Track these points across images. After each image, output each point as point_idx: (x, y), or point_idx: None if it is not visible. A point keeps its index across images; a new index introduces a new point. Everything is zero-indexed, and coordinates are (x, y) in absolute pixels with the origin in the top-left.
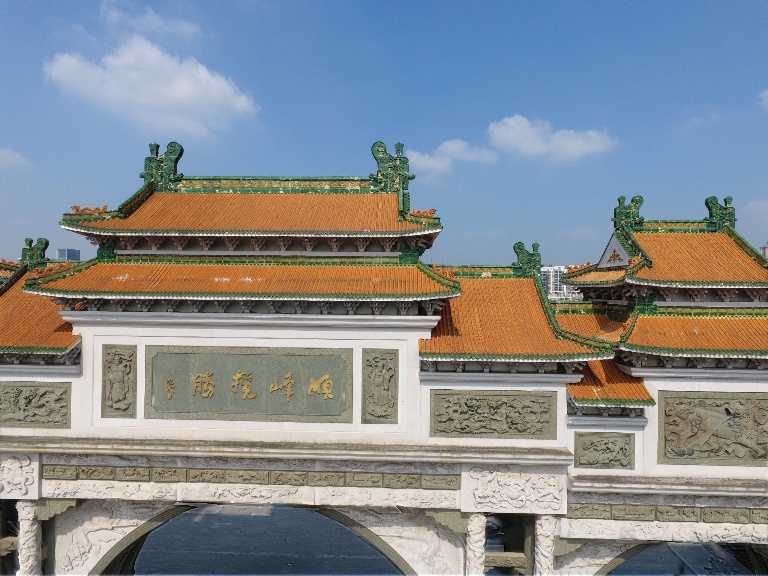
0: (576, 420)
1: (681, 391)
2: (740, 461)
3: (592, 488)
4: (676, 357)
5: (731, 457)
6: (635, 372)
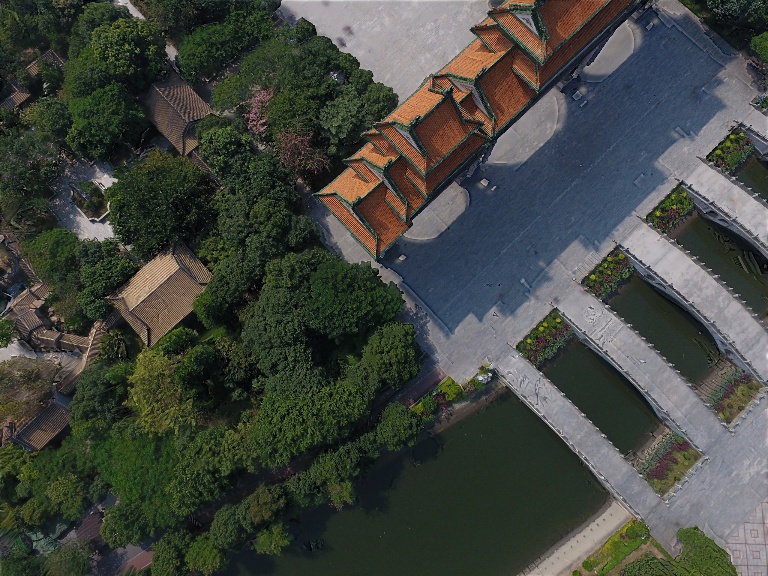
0: None
1: None
2: None
3: None
4: None
5: None
6: None
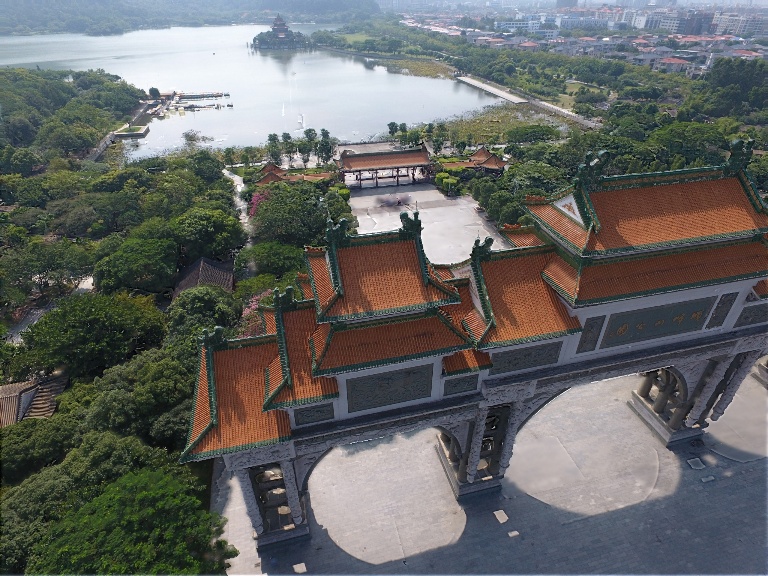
0: None
1: None
2: None
3: None
4: None
5: None
6: None
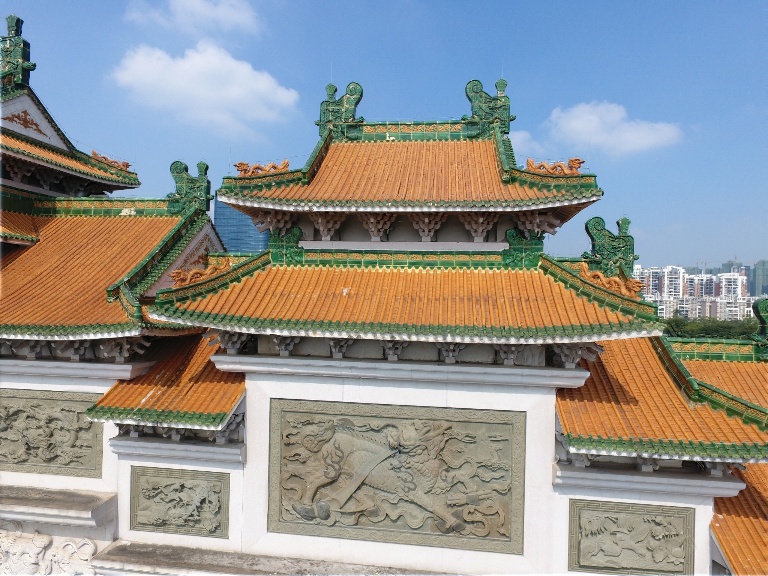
0: (120, 446)
1: (311, 400)
2: (414, 535)
3: (128, 571)
4: (274, 336)
5: (399, 527)
6: (219, 363)
